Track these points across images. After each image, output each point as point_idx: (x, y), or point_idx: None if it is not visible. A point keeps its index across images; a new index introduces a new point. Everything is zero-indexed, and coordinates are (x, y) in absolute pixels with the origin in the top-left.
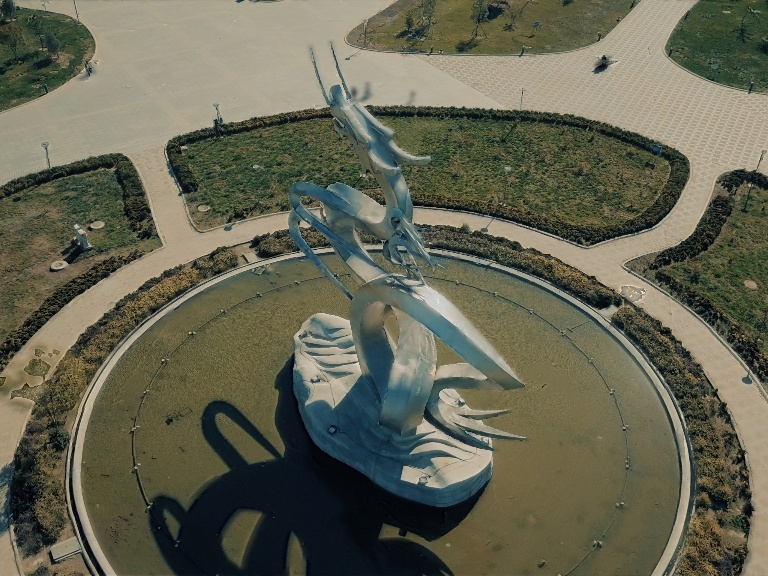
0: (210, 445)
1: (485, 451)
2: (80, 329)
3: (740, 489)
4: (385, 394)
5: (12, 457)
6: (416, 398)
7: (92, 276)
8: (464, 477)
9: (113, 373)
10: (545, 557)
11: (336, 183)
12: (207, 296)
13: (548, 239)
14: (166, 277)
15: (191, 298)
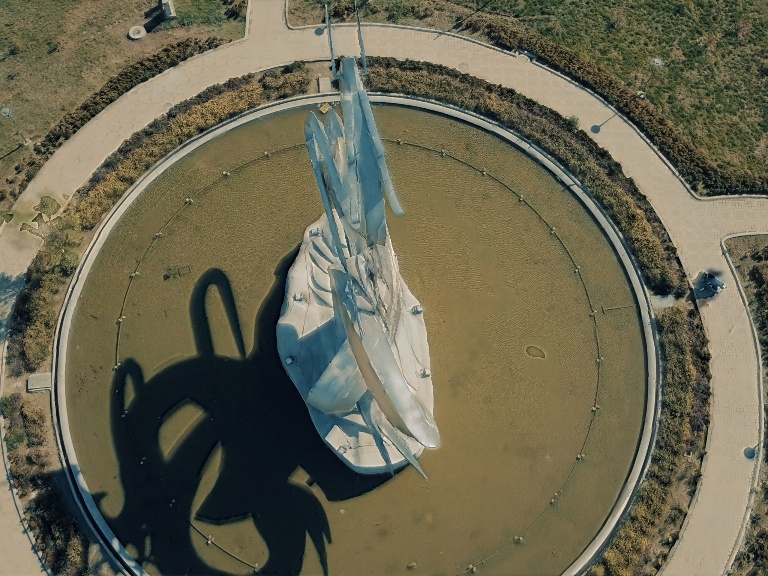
0: (191, 318)
1: None
2: (128, 130)
3: (645, 573)
4: (312, 389)
5: (27, 267)
6: (342, 400)
7: (161, 60)
8: (379, 463)
9: (139, 199)
10: (418, 560)
11: (344, 142)
12: (260, 126)
13: (661, 169)
14: (228, 89)
15: (243, 124)
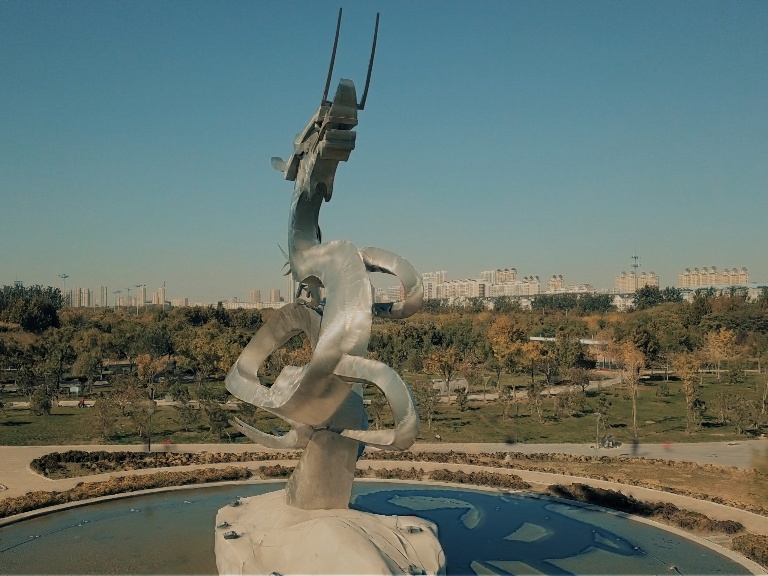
0: (577, 575)
1: (242, 501)
2: None
3: None
4: None
5: None
6: None
7: None
8: None
9: None
10: None
11: None
12: None
13: None
14: None
15: None
